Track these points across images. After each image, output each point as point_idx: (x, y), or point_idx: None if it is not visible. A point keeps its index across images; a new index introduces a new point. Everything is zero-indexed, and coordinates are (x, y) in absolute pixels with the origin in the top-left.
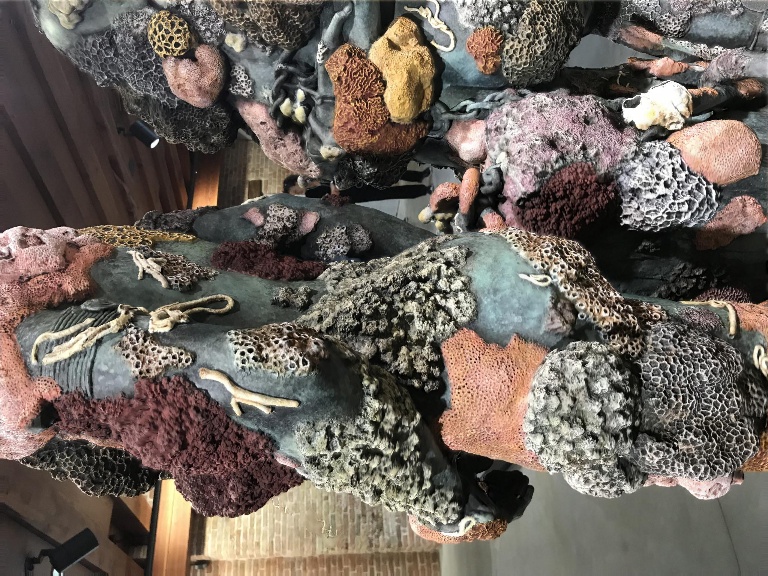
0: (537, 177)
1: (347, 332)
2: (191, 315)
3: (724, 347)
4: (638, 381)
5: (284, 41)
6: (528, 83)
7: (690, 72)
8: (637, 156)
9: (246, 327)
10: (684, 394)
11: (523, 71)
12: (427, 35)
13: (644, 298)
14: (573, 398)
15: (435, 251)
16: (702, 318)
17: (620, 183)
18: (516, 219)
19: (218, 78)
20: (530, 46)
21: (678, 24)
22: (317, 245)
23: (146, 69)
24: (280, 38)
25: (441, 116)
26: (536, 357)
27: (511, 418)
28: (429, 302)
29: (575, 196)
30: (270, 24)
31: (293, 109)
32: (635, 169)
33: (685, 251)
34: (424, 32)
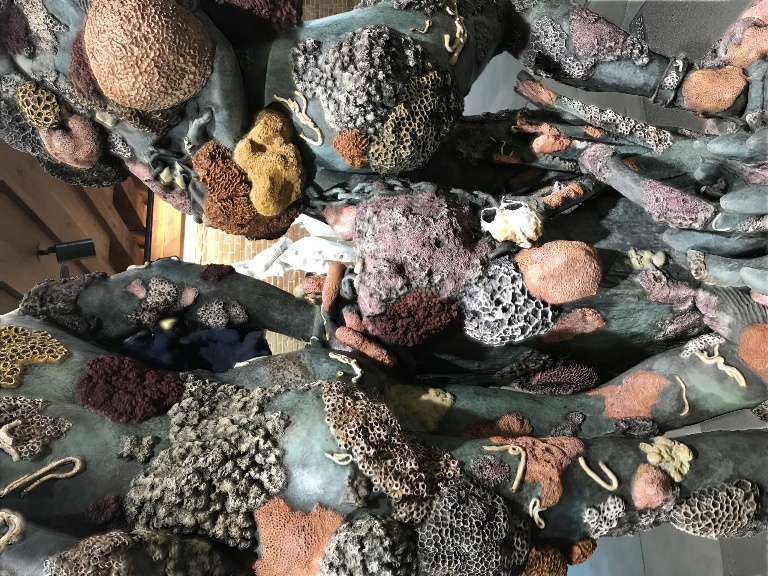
0: (383, 302)
1: (171, 506)
2: (39, 486)
3: (496, 513)
4: (414, 548)
5: (151, 132)
6: (400, 172)
7: (571, 149)
8: (481, 279)
9: (64, 548)
10: (450, 560)
11: (391, 168)
12: (297, 126)
13: (480, 399)
14: (350, 575)
15: (262, 413)
16: (492, 473)
17: (464, 303)
18: (370, 323)
19: (94, 150)
20: (395, 150)
21: (581, 69)
22: (198, 315)
23: (23, 131)
24: (146, 130)
25: (314, 201)
26: (333, 524)
27: (309, 572)
28: (243, 481)
29: (419, 316)
30: (132, 122)
31: (173, 177)
32: (477, 293)
33: (532, 342)
34: (293, 123)
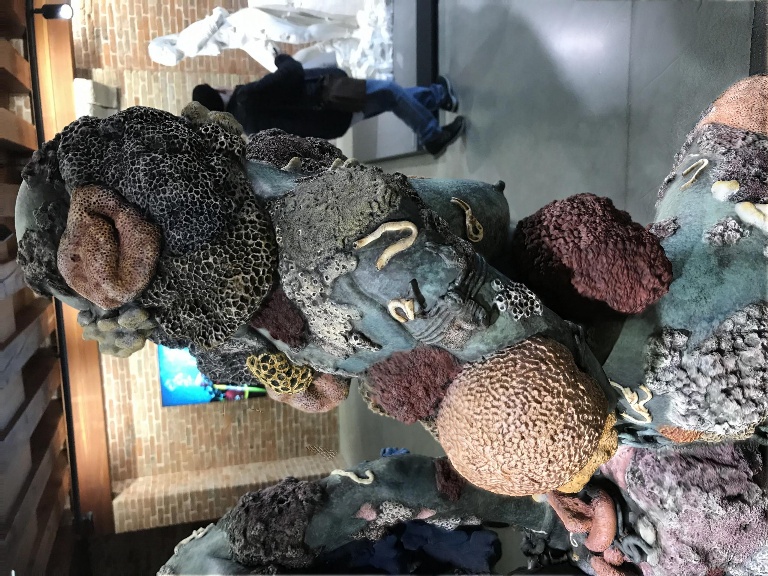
0: None
1: None
2: None
3: None
4: None
5: None
6: None
7: None
8: None
9: None
10: None
11: None
12: (619, 405)
13: None
14: None
15: None
16: None
17: None
18: None
19: None
20: None
21: None
22: None
23: (234, 371)
24: None
25: None
26: None
27: None
28: None
29: None
30: None
31: None
32: (764, 560)
33: None
34: (617, 403)
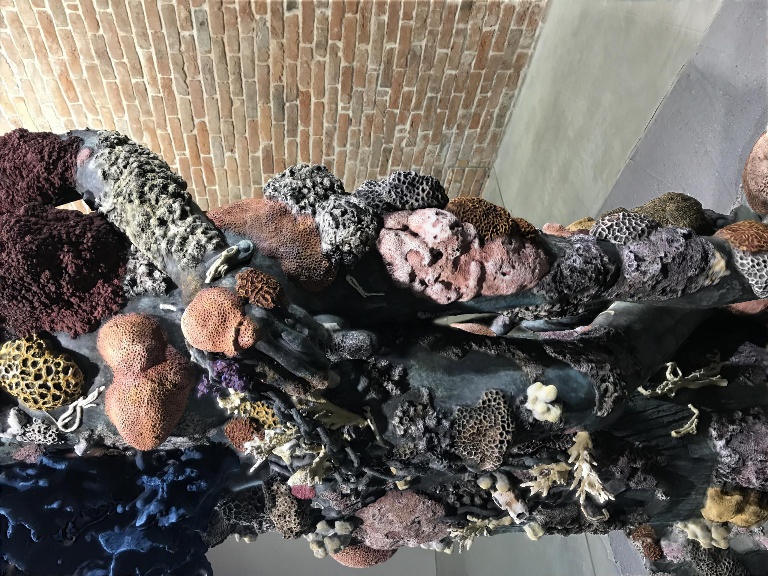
0: None
1: None
2: None
3: None
4: None
5: None
6: None
7: None
8: None
9: None
10: None
11: None
12: None
13: None
14: None
15: None
16: None
17: None
18: None
19: None
20: None
21: None
22: None
23: None
24: None
25: None
26: None
27: None
28: None
29: None
30: None
31: None
32: None
33: None
34: None
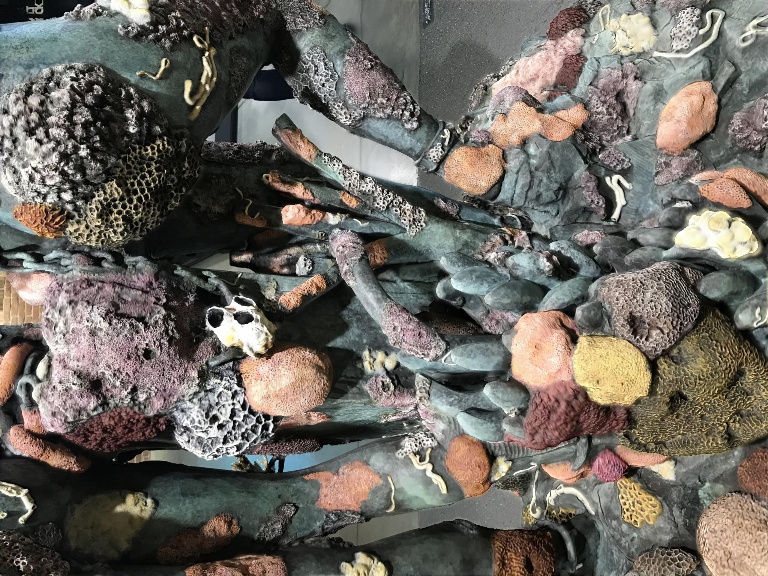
0: (69, 423)
1: None
2: None
3: None
4: None
5: None
6: None
7: (322, 224)
8: (197, 394)
9: None
10: None
11: None
12: None
13: (186, 502)
14: None
15: None
16: None
17: (174, 416)
18: None
19: None
20: (102, 231)
21: (349, 119)
22: None
23: None
24: None
25: None
26: None
27: None
28: None
29: (117, 433)
30: None
31: None
32: (191, 409)
33: None
34: None
